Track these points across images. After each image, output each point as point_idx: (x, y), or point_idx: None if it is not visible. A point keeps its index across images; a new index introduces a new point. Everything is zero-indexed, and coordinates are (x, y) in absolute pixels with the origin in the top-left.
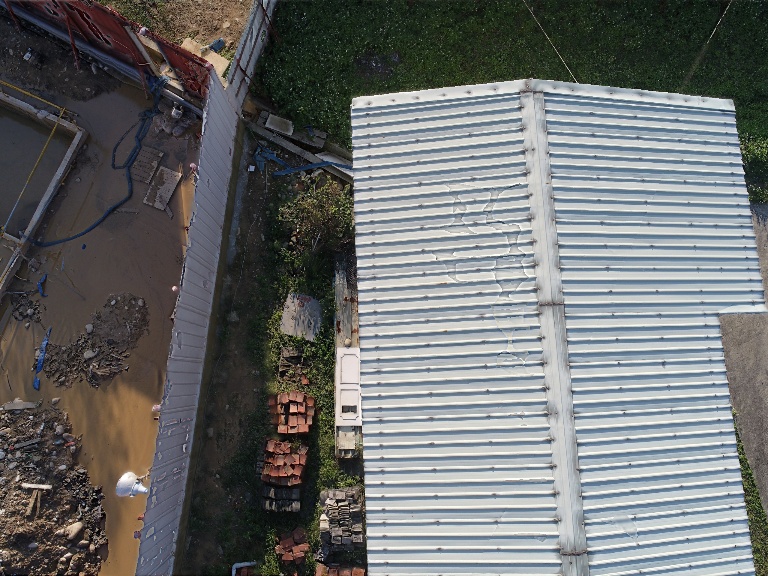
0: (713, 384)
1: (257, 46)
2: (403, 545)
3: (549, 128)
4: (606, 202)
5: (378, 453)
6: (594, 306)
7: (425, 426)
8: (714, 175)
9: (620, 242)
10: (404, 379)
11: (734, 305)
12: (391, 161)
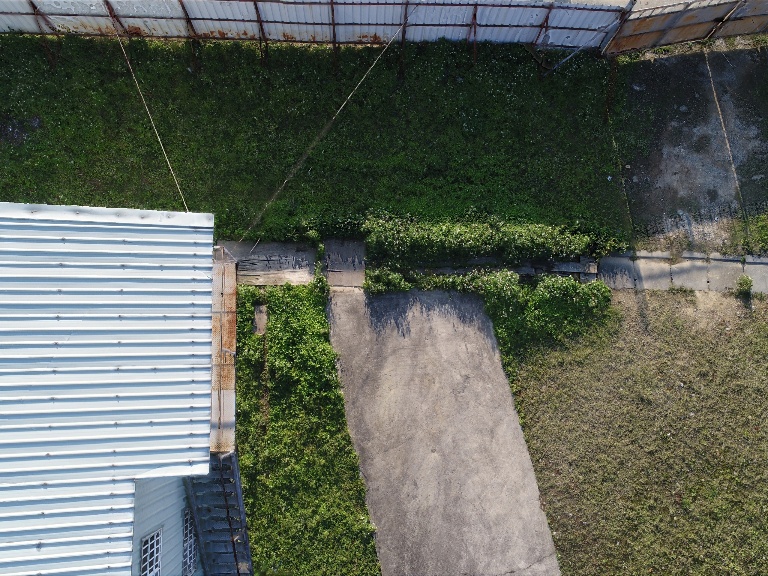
0: (108, 568)
1: None
2: None
3: None
4: None
5: None
6: None
7: None
8: (166, 307)
9: (7, 395)
10: None
11: (162, 467)
12: None
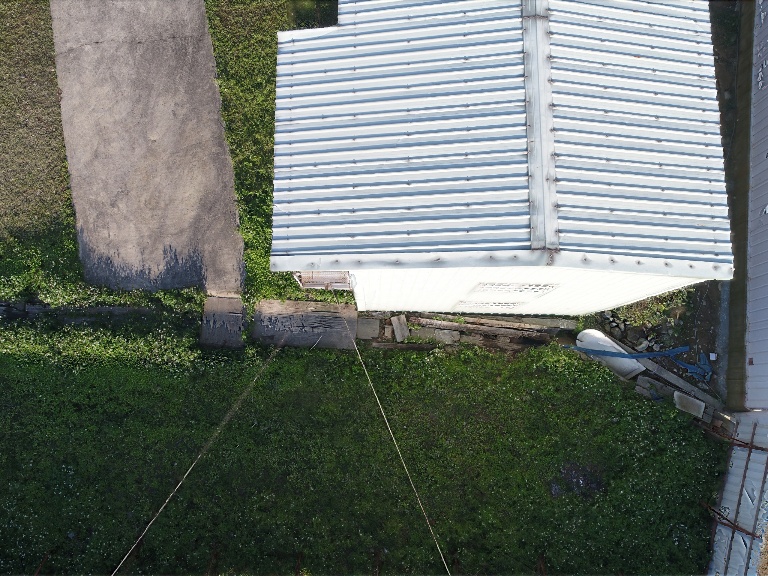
0: None
1: (732, 497)
2: None
3: (525, 208)
4: (459, 130)
5: None
6: (486, 20)
7: None
8: (314, 175)
9: (447, 89)
10: None
11: (317, 38)
12: (690, 197)
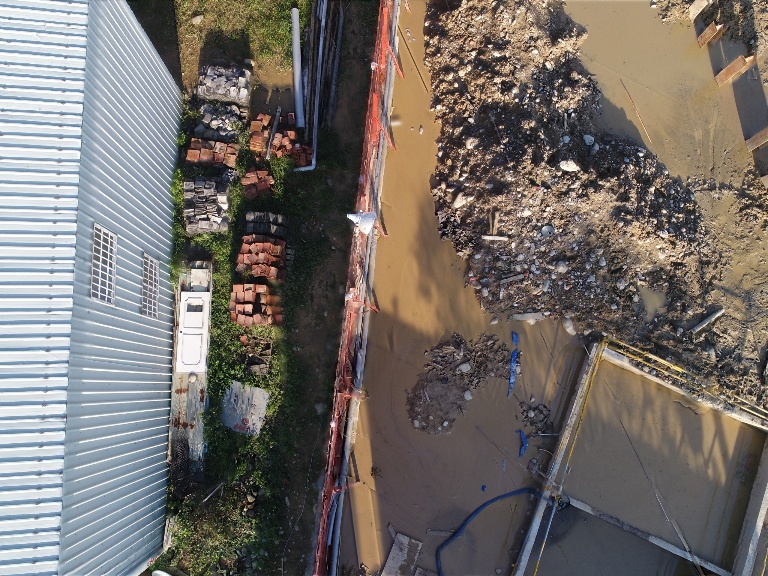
0: None
1: None
2: (41, 141)
3: None
4: None
5: (60, 228)
6: None
7: (1, 252)
8: None
9: None
10: (20, 302)
11: None
12: (4, 570)
